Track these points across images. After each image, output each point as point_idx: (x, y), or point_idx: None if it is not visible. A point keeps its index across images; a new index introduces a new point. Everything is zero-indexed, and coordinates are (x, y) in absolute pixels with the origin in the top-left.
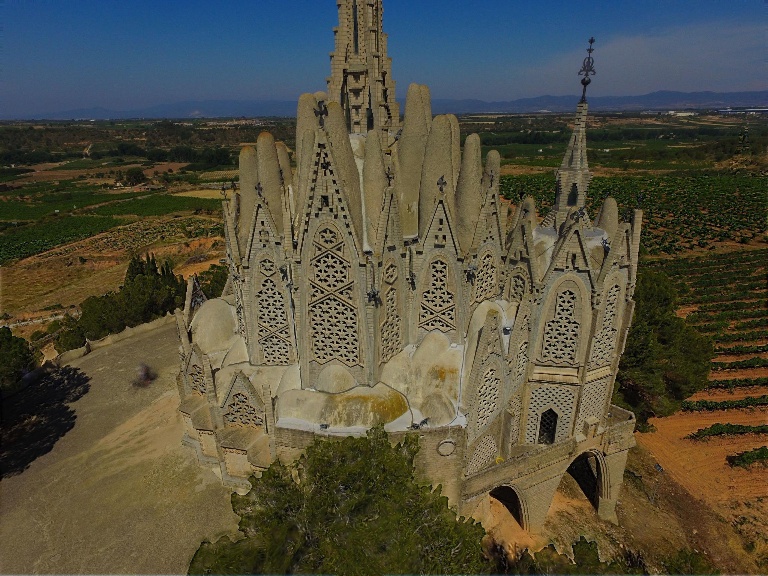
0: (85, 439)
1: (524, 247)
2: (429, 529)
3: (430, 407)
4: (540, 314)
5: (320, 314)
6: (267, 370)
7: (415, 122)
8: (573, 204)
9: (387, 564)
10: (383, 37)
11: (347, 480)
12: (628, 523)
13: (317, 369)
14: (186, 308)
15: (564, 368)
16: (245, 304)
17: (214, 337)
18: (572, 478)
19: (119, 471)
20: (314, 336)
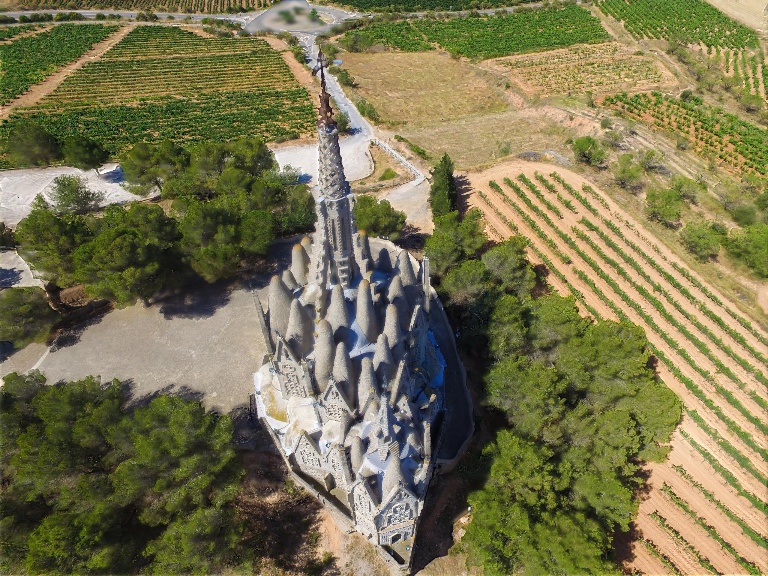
0: None
1: None
2: None
3: None
4: None
5: None
6: None
7: (332, 307)
8: None
9: None
10: (354, 236)
11: None
12: None
13: None
14: None
15: None
16: None
17: None
18: None
19: None
20: None
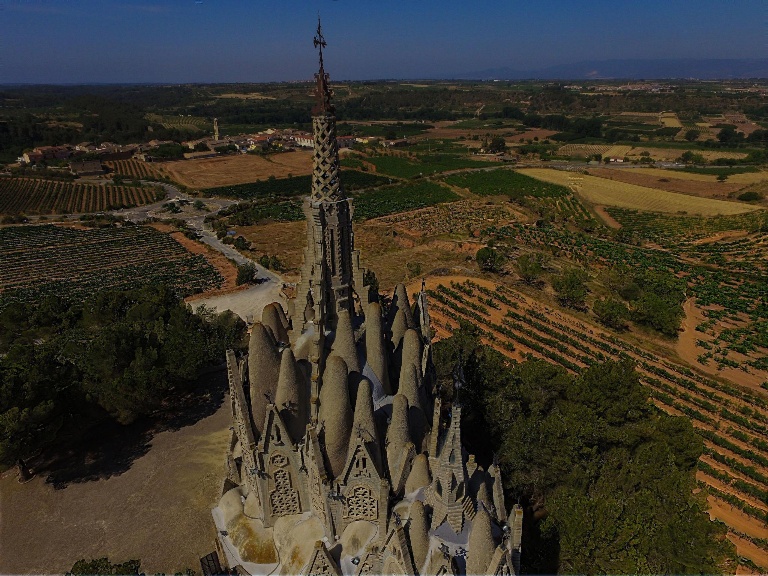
0: (209, 427)
1: None
2: None
3: None
4: (382, 571)
5: None
6: None
7: (339, 345)
8: (440, 494)
9: None
10: (353, 254)
11: None
12: None
13: None
14: None
15: None
16: None
17: None
18: None
19: (199, 462)
20: None
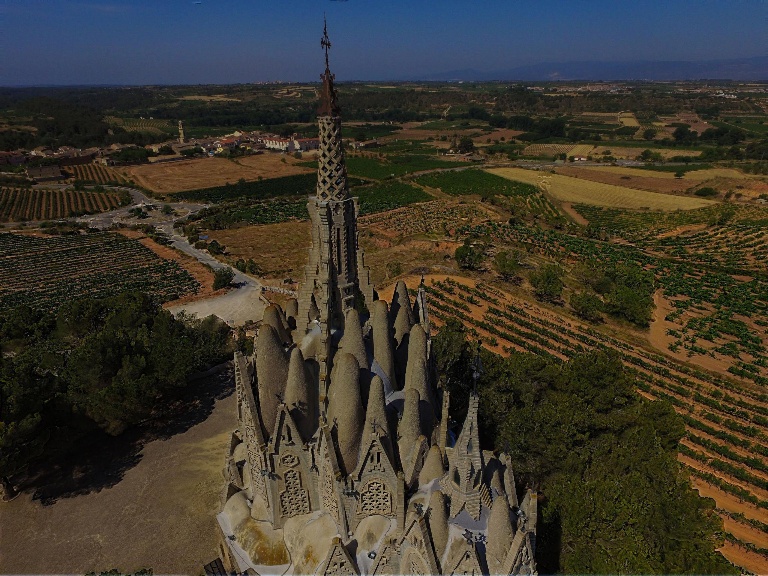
0: (202, 434)
1: None
2: None
3: None
4: (400, 563)
5: None
6: None
7: (348, 342)
8: (458, 483)
9: None
10: (358, 253)
11: None
12: None
13: None
14: None
15: None
16: None
17: None
18: None
19: (194, 470)
20: None
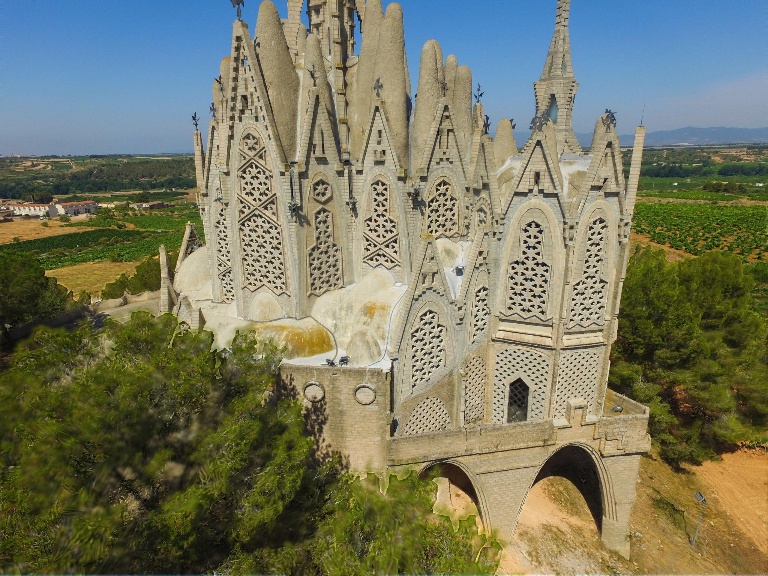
0: None
1: (486, 171)
2: (233, 431)
3: (353, 345)
4: (501, 252)
5: (249, 233)
6: (222, 306)
7: (372, 34)
8: (553, 122)
9: (85, 414)
10: None
11: (126, 344)
12: (644, 560)
13: (249, 297)
14: (181, 253)
15: (535, 326)
16: (206, 235)
17: (194, 278)
18: (578, 492)
19: None
20: (245, 259)
